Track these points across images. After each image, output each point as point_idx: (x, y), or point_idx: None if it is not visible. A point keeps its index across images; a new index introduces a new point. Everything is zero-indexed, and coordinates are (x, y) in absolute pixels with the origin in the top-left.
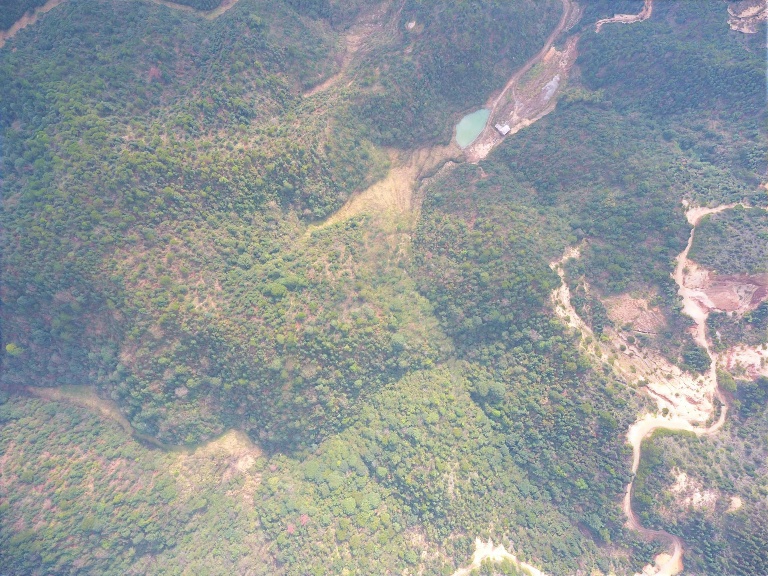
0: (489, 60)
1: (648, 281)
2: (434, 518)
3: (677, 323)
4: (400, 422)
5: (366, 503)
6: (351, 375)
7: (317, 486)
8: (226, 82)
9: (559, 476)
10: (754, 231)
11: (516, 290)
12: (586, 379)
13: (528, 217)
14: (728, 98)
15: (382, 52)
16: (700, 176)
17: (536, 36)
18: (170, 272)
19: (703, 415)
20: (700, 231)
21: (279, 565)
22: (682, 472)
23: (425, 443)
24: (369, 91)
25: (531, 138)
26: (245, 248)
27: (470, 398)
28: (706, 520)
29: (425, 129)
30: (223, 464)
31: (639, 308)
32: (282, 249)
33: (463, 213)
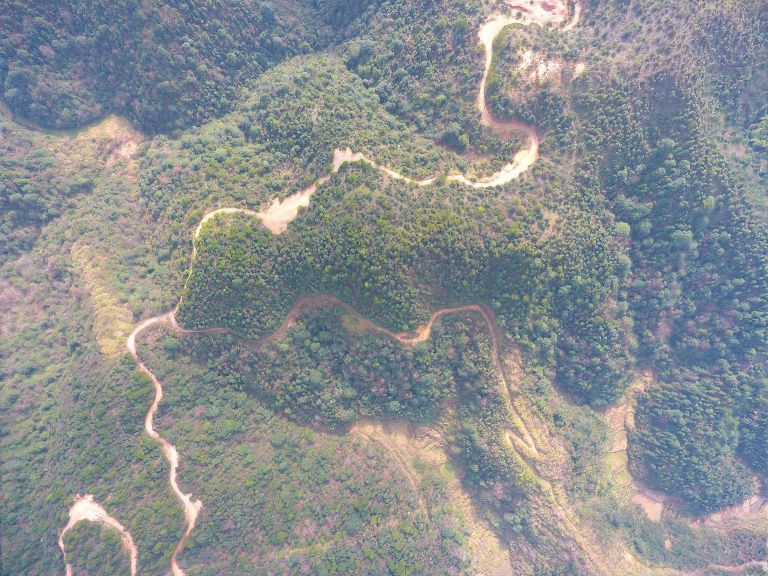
0: None
1: None
2: (301, 152)
3: None
4: None
5: (236, 149)
6: (221, 41)
7: None
8: None
9: (422, 101)
10: None
11: None
12: (444, 3)
13: None
14: None
15: None
16: None
17: None
18: None
19: (557, 18)
20: None
21: None
22: (528, 50)
23: (294, 93)
24: None
25: None
26: None
27: (346, 68)
28: (553, 94)
29: None
30: (105, 148)
31: None
32: None
33: None
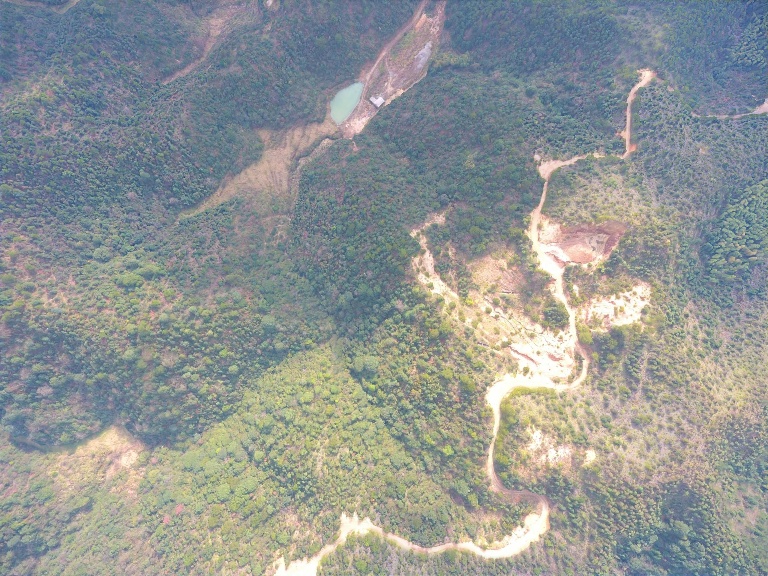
0: (352, 32)
1: (505, 240)
2: (306, 497)
3: (533, 280)
4: (276, 404)
5: (240, 488)
6: (222, 361)
7: (195, 475)
8: (69, 74)
9: (429, 445)
10: (602, 180)
11: (378, 261)
12: (449, 345)
13: (394, 187)
14: (586, 48)
15: (241, 32)
16: (559, 130)
17: (401, 4)
18: (14, 270)
19: (565, 371)
20: (552, 185)
21: (160, 557)
22: (537, 429)
23: (297, 423)
24: (226, 73)
25: (401, 108)
26: (102, 241)
27: (349, 375)
28: (564, 476)
29: (294, 108)
30: (105, 461)
31: (500, 269)
32: (146, 240)
33: (334, 189)
